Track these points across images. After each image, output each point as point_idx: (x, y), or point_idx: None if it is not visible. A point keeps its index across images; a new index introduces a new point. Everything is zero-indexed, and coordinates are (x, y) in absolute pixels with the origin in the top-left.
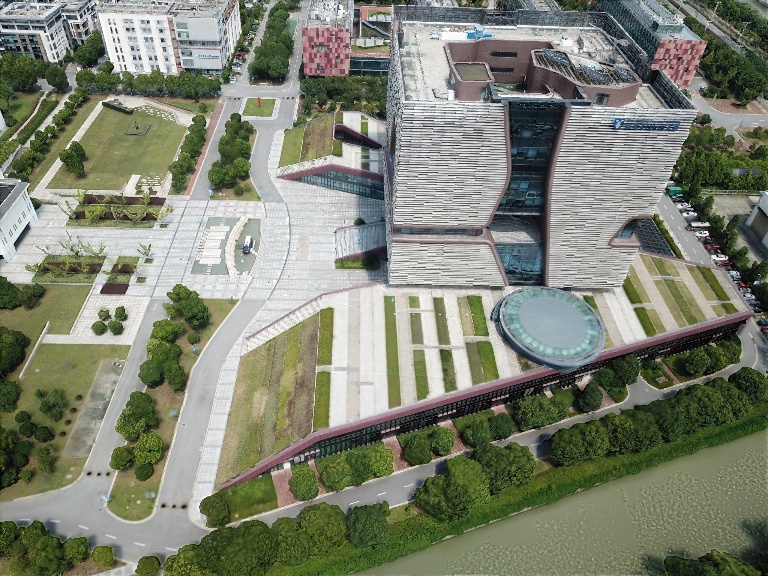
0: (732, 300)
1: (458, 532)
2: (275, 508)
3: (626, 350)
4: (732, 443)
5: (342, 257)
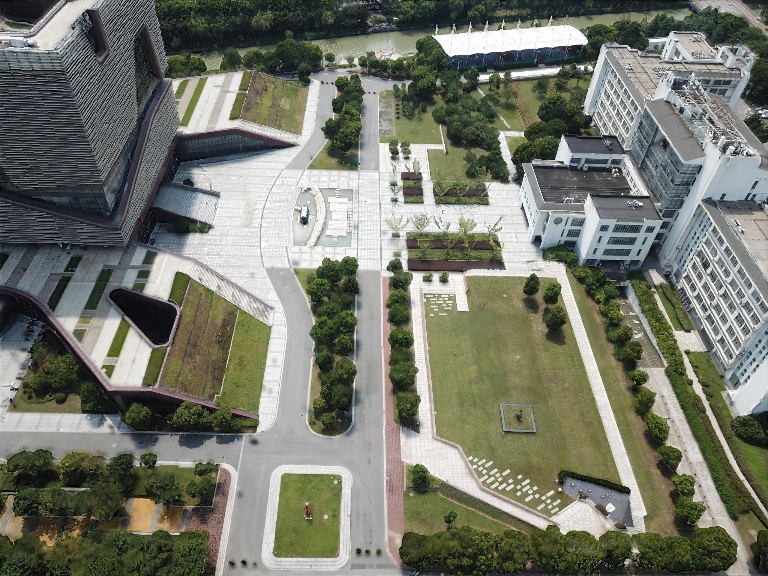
0: None
1: None
2: None
3: None
4: None
5: (212, 191)
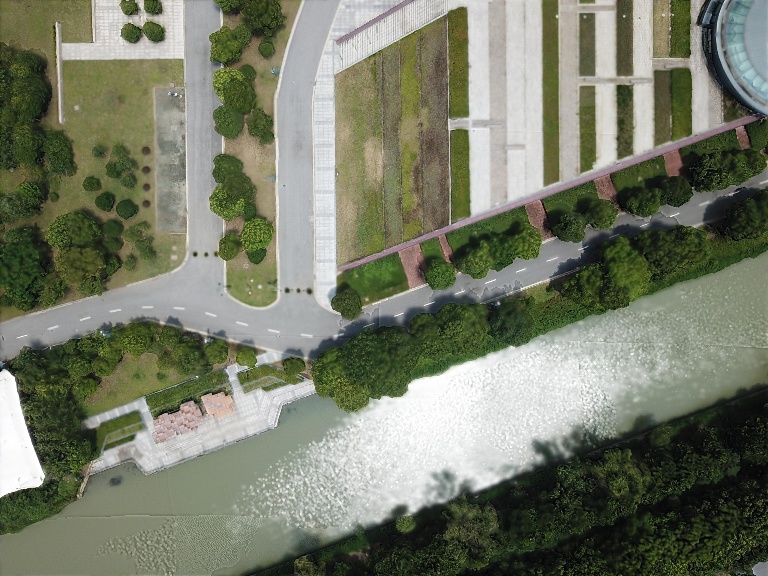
0: None
1: (601, 313)
2: (406, 290)
3: None
4: None
5: None
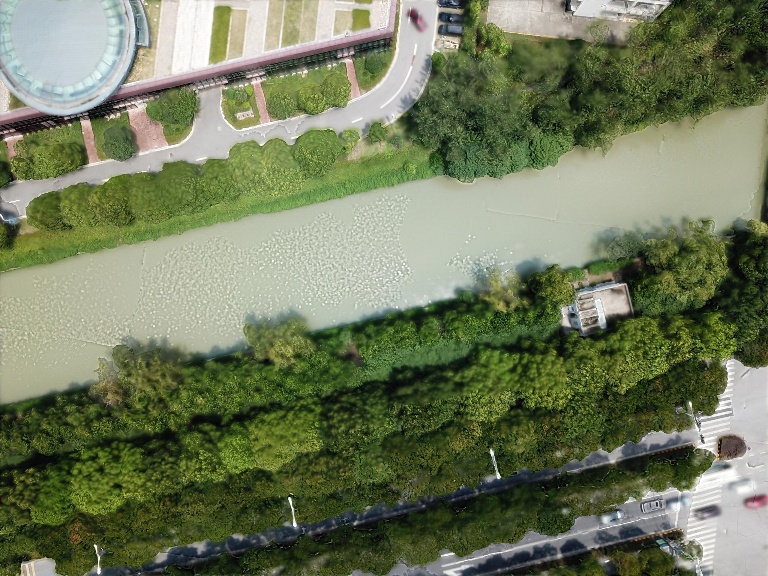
0: (376, 3)
1: None
2: None
3: (169, 84)
4: (298, 209)
5: None
